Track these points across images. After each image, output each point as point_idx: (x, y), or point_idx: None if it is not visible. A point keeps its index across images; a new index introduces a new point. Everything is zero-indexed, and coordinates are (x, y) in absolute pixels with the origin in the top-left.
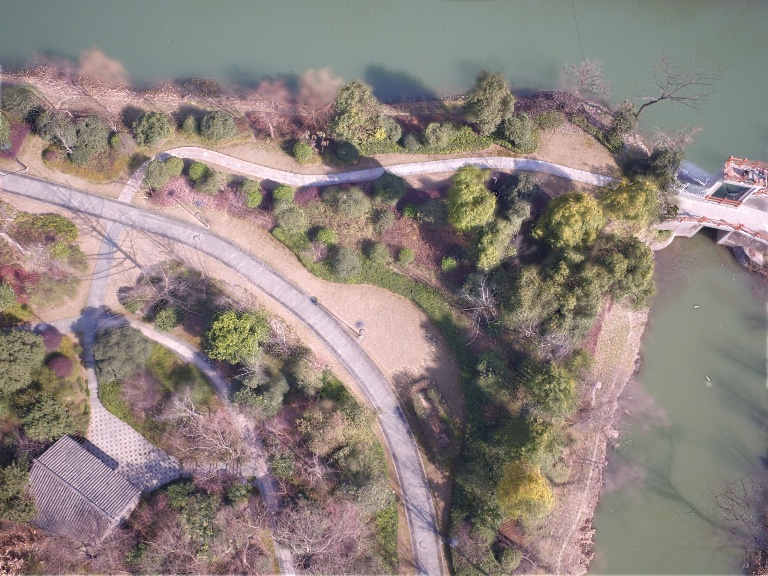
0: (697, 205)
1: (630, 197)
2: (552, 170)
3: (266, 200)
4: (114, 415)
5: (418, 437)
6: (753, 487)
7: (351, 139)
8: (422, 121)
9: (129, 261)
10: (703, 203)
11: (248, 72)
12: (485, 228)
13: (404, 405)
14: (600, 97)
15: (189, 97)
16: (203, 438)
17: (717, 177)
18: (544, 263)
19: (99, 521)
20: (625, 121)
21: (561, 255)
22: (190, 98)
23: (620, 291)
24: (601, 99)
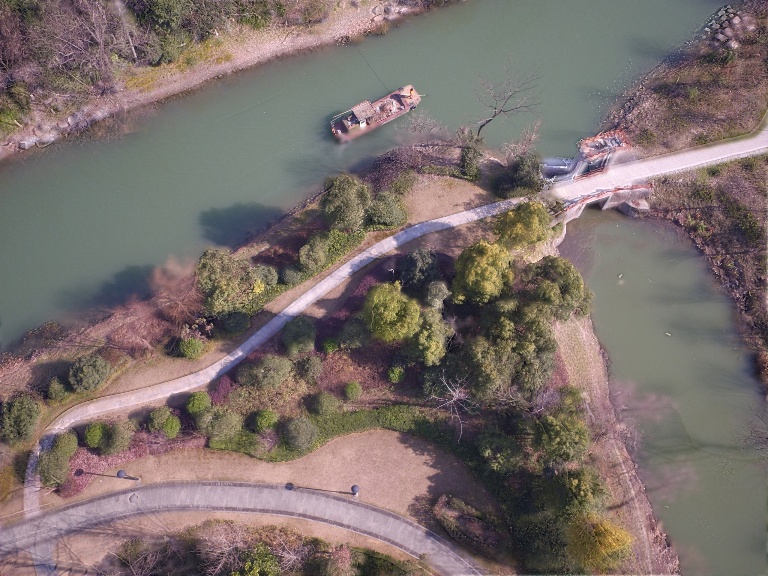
0: (570, 188)
1: (524, 224)
2: (432, 228)
3: (184, 418)
4: None
5: (468, 558)
6: None
7: (233, 309)
8: (286, 247)
9: (76, 569)
10: (574, 184)
11: (83, 292)
12: (417, 329)
13: (436, 535)
14: (428, 133)
15: (37, 354)
16: None
17: (576, 158)
18: (486, 327)
19: None
20: (469, 149)
21: (497, 312)
22: (38, 354)
23: (565, 313)
24: (430, 135)
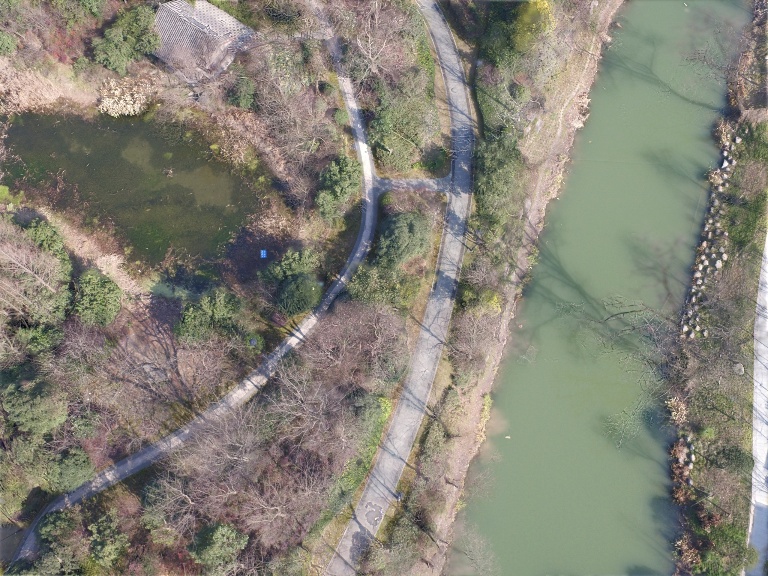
0: None
1: None
2: None
3: None
4: (213, 5)
5: (451, 23)
6: (714, 36)
7: None
8: None
9: None
10: None
11: None
12: None
13: (440, 3)
14: None
15: None
16: (283, 15)
17: None
18: None
19: (209, 44)
20: None
21: None
22: None
23: None
24: None
